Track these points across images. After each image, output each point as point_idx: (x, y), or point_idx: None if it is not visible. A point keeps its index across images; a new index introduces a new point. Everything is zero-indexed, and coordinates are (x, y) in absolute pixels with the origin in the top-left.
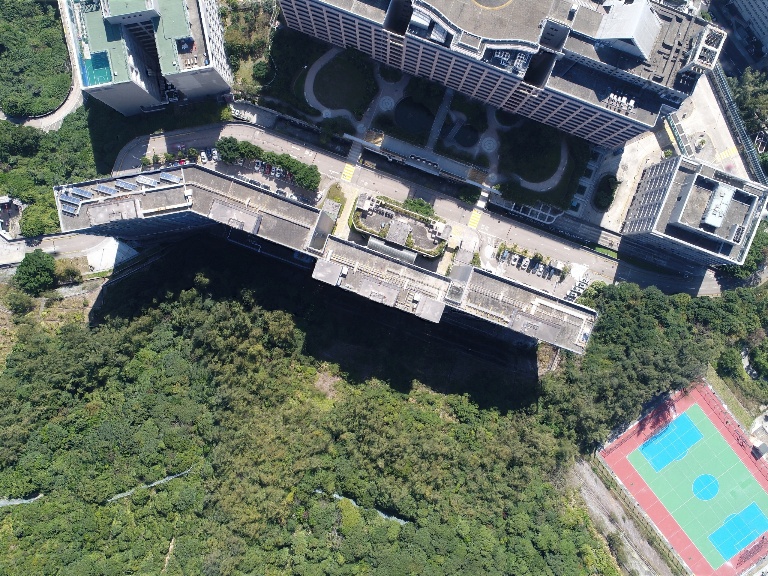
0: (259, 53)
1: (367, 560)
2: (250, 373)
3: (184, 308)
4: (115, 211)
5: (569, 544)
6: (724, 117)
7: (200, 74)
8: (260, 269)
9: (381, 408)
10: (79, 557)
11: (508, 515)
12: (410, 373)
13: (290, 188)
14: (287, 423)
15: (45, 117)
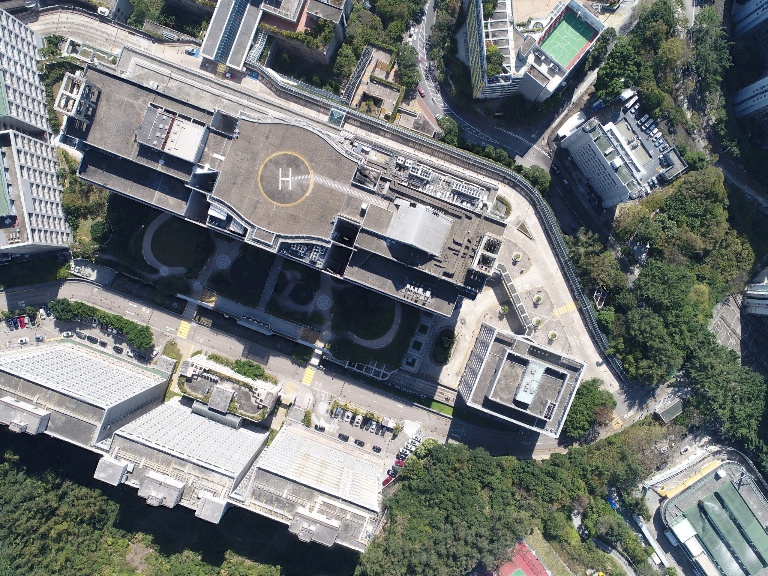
0: (98, 212)
1: None
2: (53, 553)
3: None
4: None
5: None
6: (562, 273)
7: (23, 247)
8: None
9: None
10: None
11: None
12: (227, 542)
13: (127, 344)
14: None
15: None
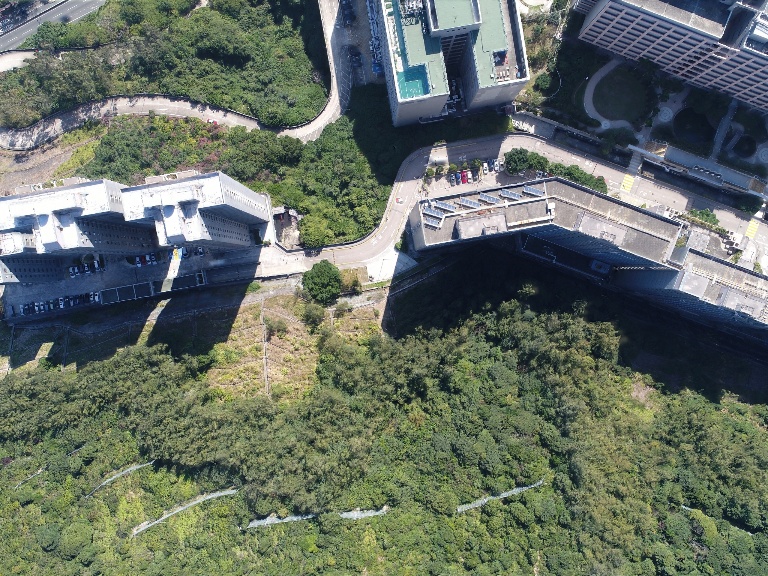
0: (540, 64)
1: (730, 571)
2: (583, 384)
3: (505, 319)
4: (486, 225)
5: None
6: None
7: (510, 86)
8: (564, 280)
9: None
10: (445, 569)
11: None
12: (714, 383)
13: None
14: (621, 434)
15: (300, 127)
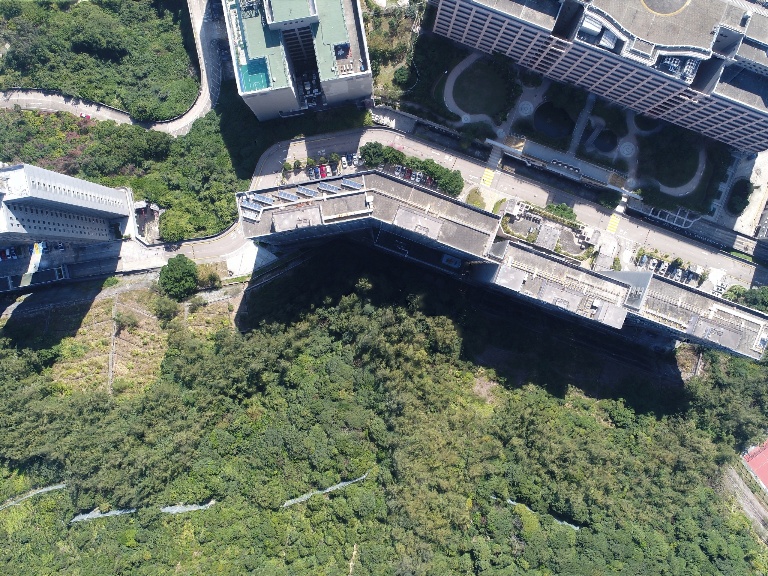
0: (399, 58)
1: (548, 566)
2: (416, 379)
3: (344, 314)
4: (300, 218)
5: (737, 549)
6: None
7: (355, 80)
8: (412, 274)
9: (544, 413)
10: (262, 563)
11: (676, 520)
12: (562, 378)
13: None
14: (454, 428)
15: (172, 122)
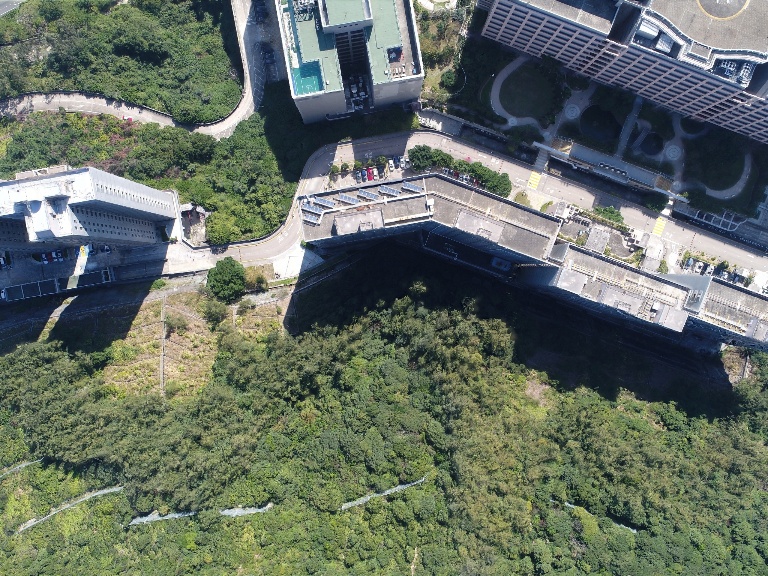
0: (446, 61)
1: (609, 568)
2: (472, 381)
3: (398, 316)
4: (363, 221)
5: None
6: None
7: (406, 83)
8: (462, 277)
9: (598, 416)
10: (323, 566)
11: (732, 523)
12: (613, 381)
13: None
14: (510, 431)
15: (215, 124)
